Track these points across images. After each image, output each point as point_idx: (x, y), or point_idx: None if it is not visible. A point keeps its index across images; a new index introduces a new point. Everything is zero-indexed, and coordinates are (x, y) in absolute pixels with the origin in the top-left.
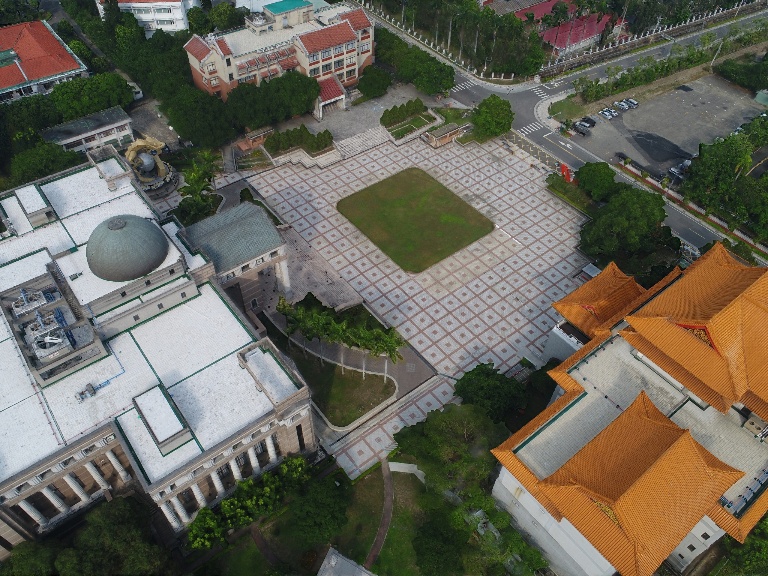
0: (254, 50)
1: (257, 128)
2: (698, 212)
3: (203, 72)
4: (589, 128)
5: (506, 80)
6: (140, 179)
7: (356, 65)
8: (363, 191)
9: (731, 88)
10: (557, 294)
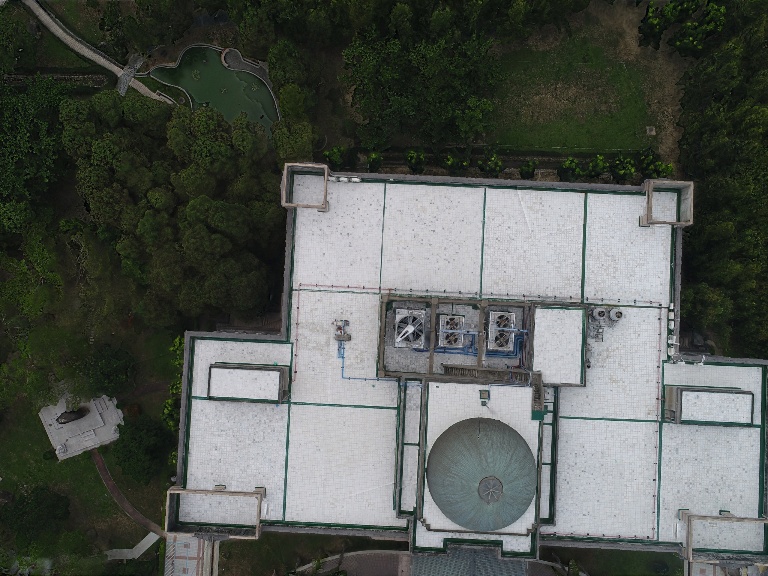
0: None
1: None
2: None
3: None
4: None
5: None
6: None
7: None
8: None
9: None
10: None
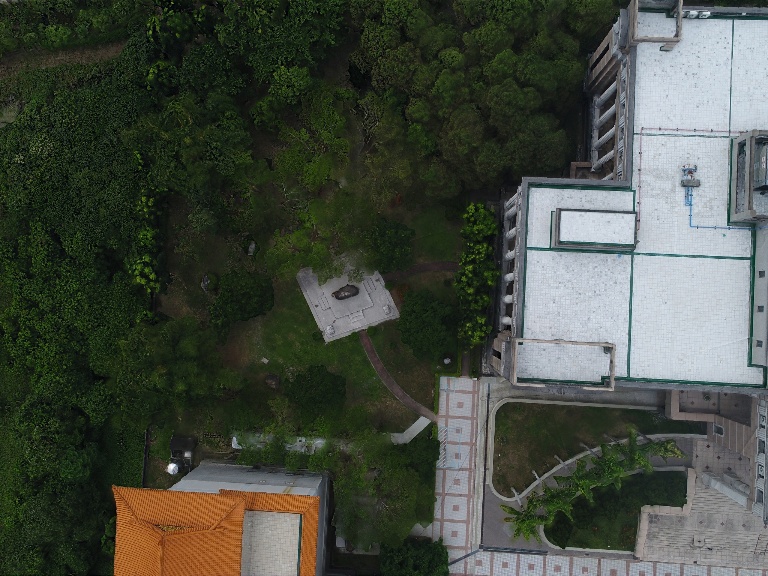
0: None
1: None
2: None
3: None
4: None
5: None
6: None
7: None
8: None
9: None
10: None
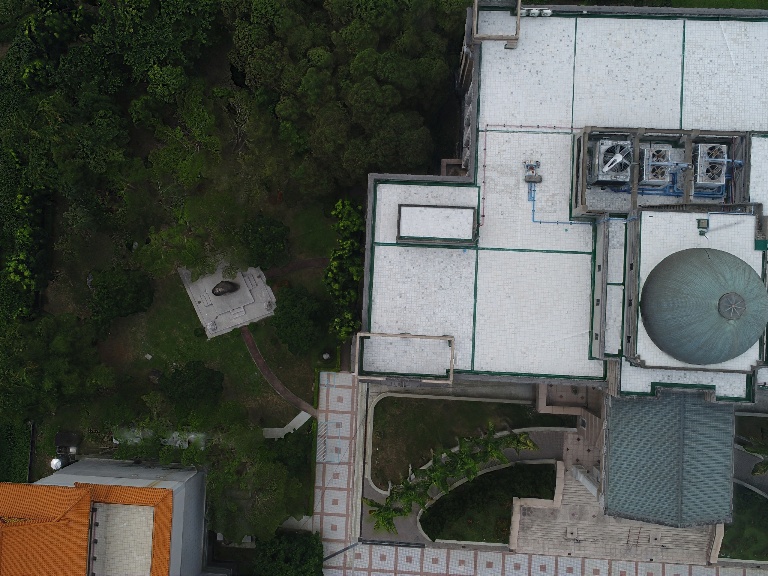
0: None
1: None
2: None
3: None
4: None
5: None
6: None
7: None
8: None
9: None
10: None
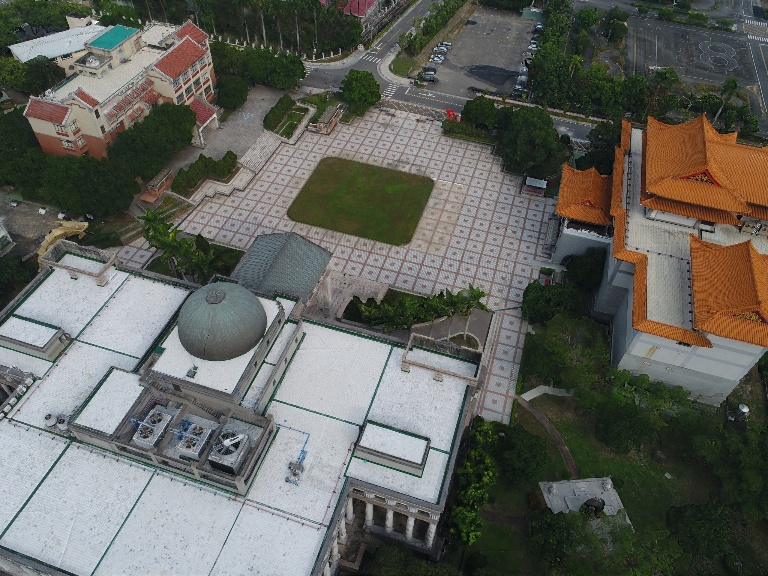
0: (112, 94)
1: (155, 174)
2: (555, 112)
3: (64, 135)
4: (434, 75)
5: (336, 56)
6: None
7: (210, 80)
8: (301, 195)
9: (500, 13)
10: (520, 211)
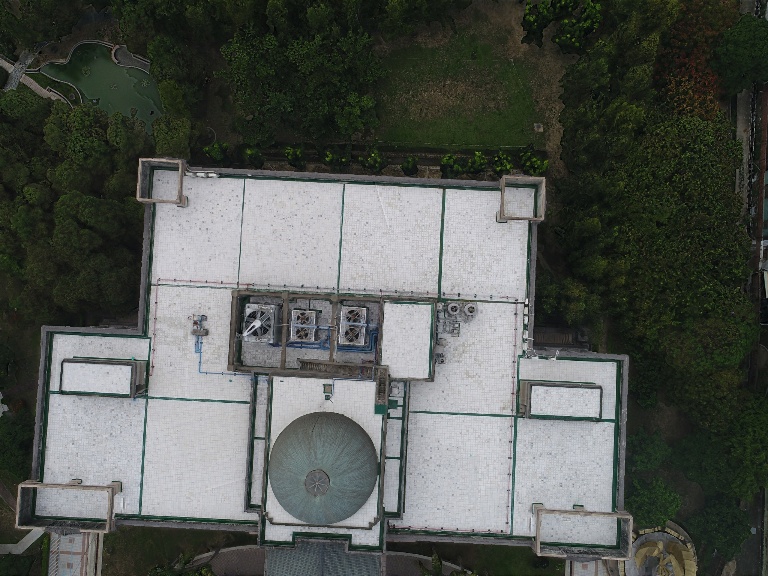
0: None
1: None
2: None
3: None
4: None
5: None
6: (643, 549)
7: None
8: None
9: None
10: None
